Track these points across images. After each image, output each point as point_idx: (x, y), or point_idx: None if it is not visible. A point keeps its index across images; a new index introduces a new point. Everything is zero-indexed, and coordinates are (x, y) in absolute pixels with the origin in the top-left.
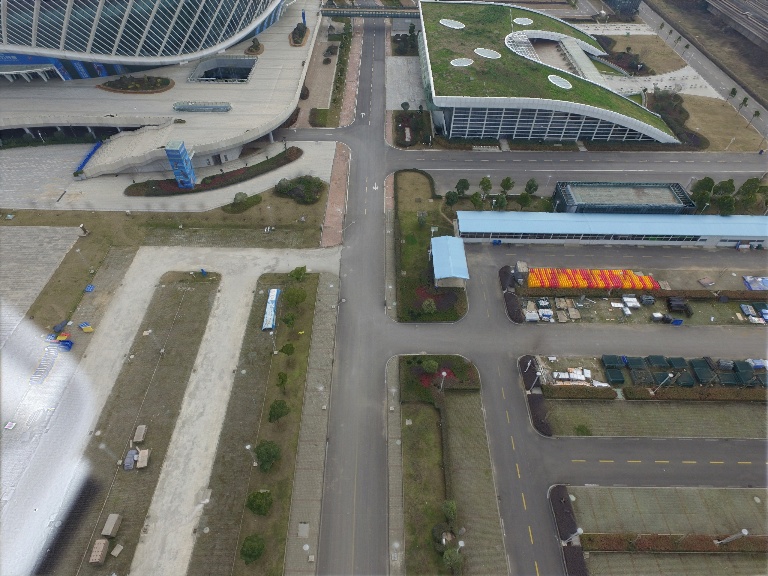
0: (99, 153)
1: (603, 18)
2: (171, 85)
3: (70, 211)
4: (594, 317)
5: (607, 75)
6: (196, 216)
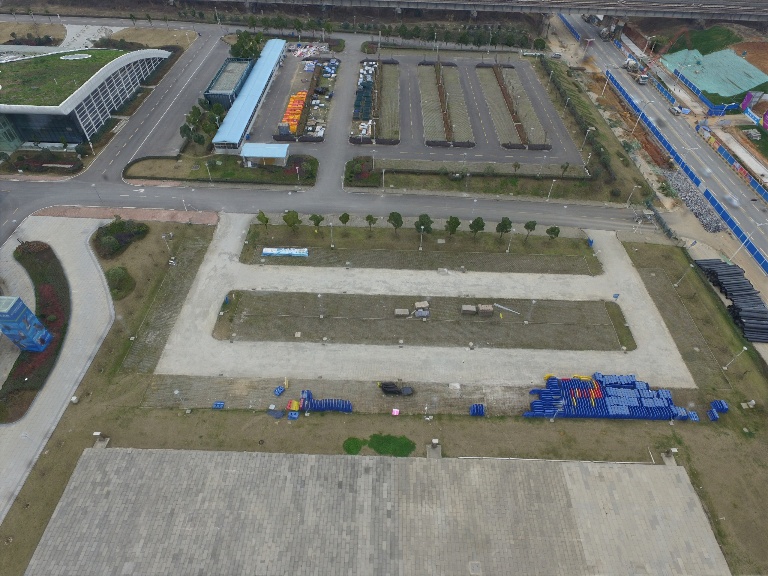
0: None
1: None
2: None
3: (22, 491)
4: None
5: None
6: (121, 323)
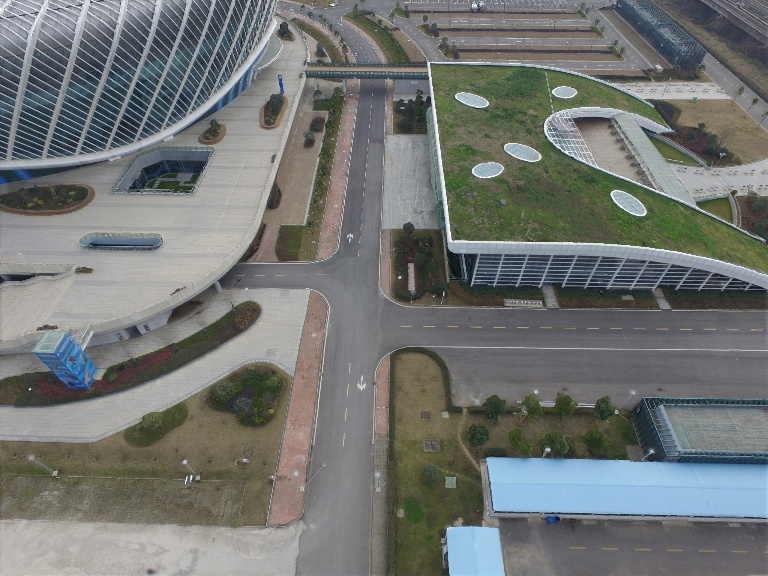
0: None
1: (659, 74)
2: (89, 199)
3: None
4: None
5: (677, 165)
6: (82, 452)
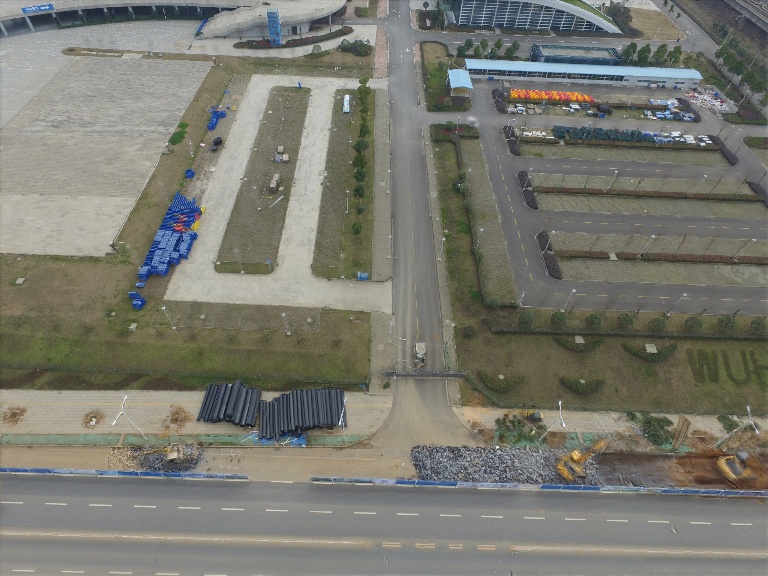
0: (208, 25)
1: None
2: None
3: (200, 54)
4: (551, 113)
5: None
6: (287, 60)
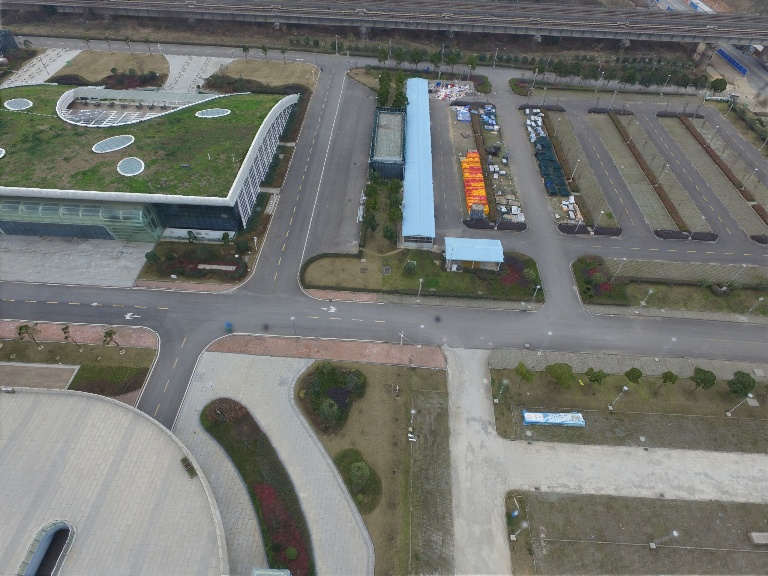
0: None
1: (8, 65)
2: None
3: None
4: (510, 189)
5: None
6: (385, 560)
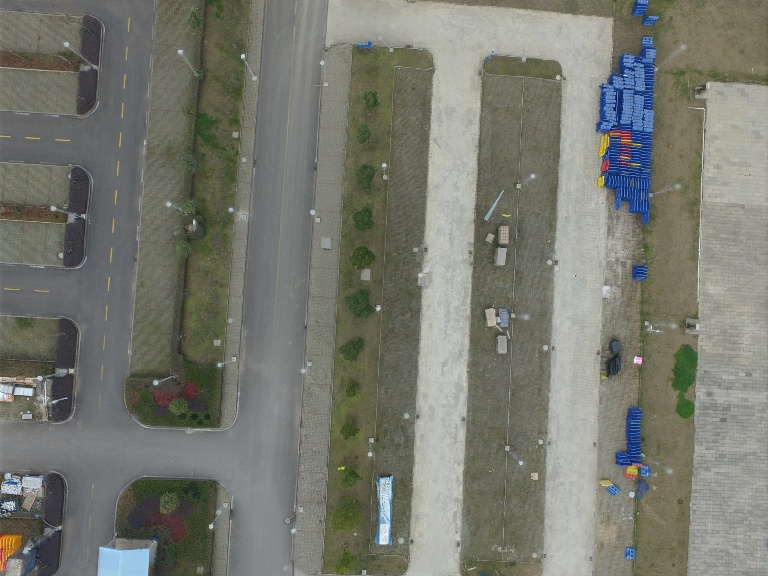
0: None
1: None
2: None
3: None
4: None
5: None
6: None
